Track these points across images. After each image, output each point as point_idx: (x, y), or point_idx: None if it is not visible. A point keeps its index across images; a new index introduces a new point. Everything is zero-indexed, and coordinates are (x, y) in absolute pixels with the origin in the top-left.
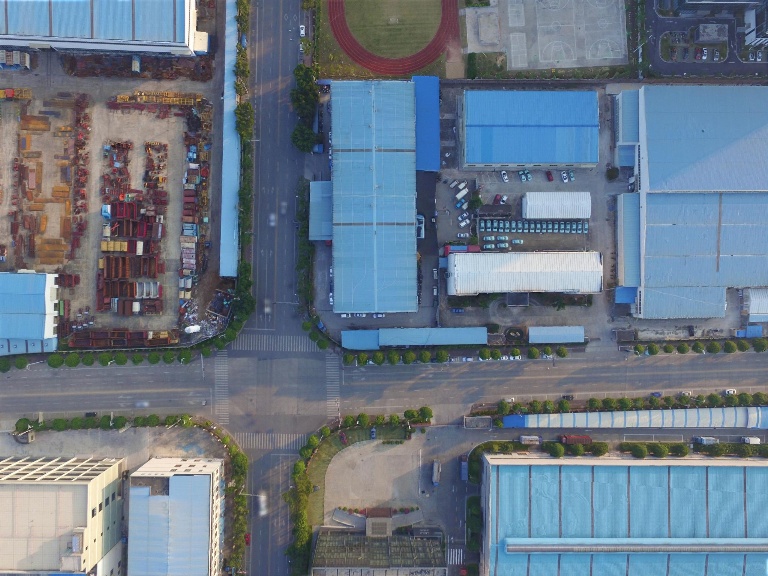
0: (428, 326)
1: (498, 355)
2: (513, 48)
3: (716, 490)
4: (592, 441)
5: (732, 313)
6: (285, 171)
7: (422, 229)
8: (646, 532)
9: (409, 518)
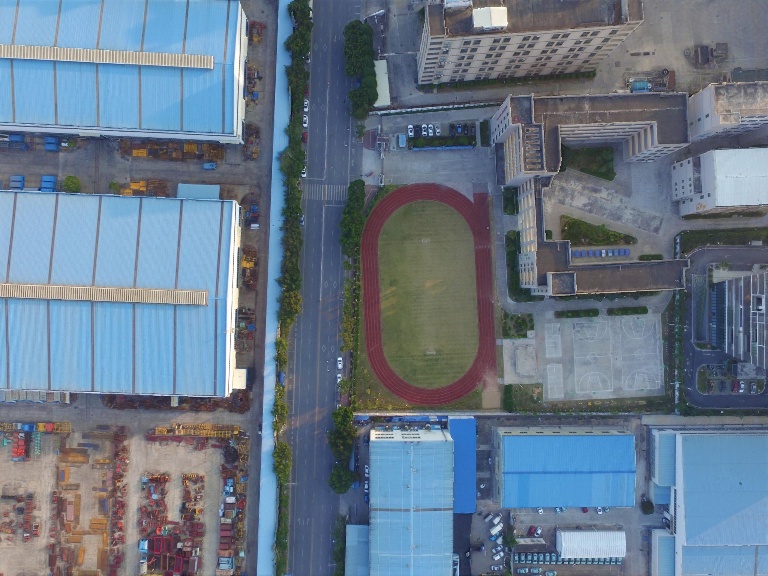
0: None
1: None
2: (550, 379)
3: None
4: None
5: None
6: (321, 502)
7: (457, 570)
8: None
9: None
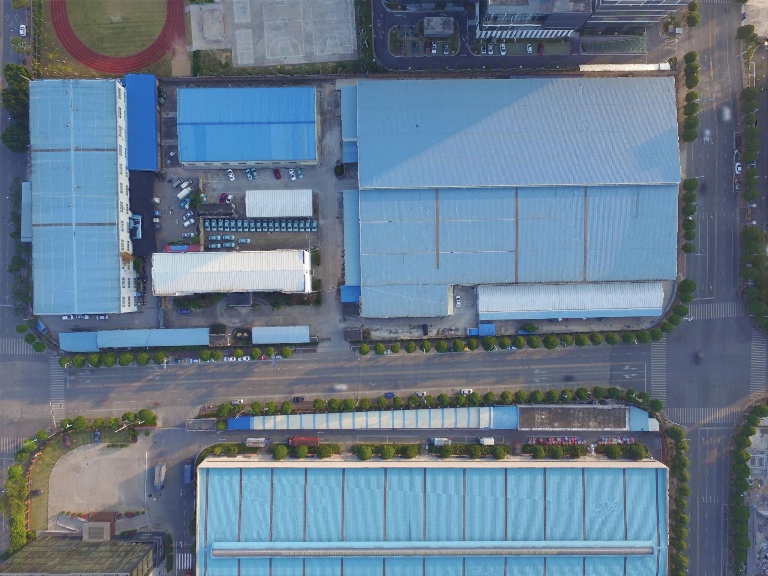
0: (153, 327)
1: (217, 356)
2: (239, 45)
3: (434, 492)
4: (324, 443)
5: (468, 311)
6: (7, 172)
7: (138, 229)
8: (360, 535)
9: (135, 522)
